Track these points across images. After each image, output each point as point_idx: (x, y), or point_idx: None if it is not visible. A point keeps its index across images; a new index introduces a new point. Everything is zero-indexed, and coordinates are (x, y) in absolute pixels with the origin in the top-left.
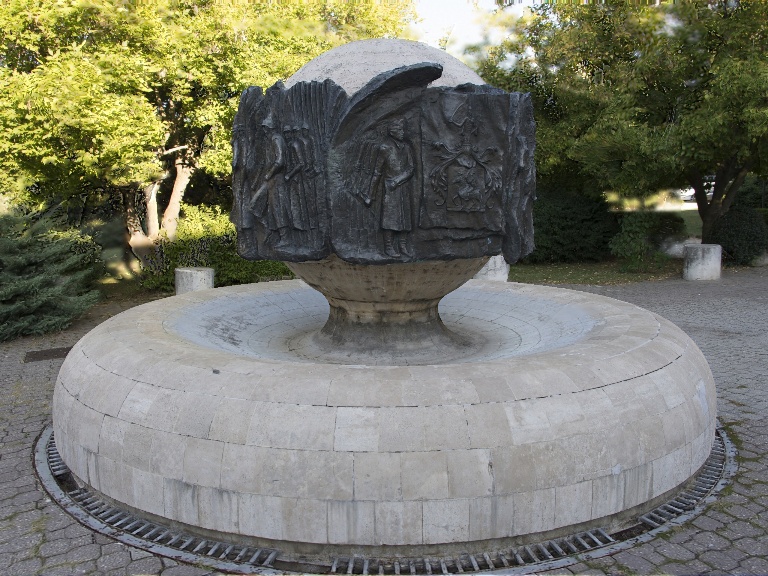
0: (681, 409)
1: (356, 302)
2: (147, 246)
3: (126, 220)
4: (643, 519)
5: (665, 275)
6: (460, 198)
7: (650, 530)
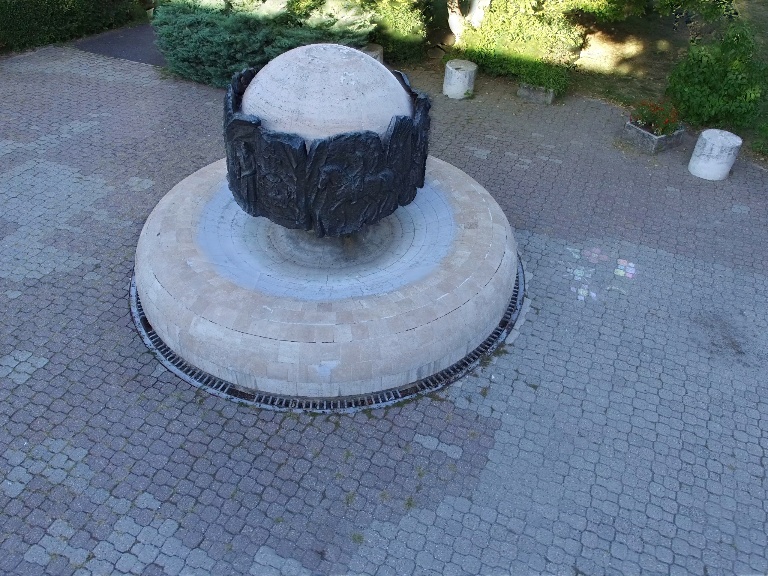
0: (290, 365)
1: None
2: (460, 26)
3: (447, 1)
4: (257, 395)
5: None
6: None
7: (247, 400)
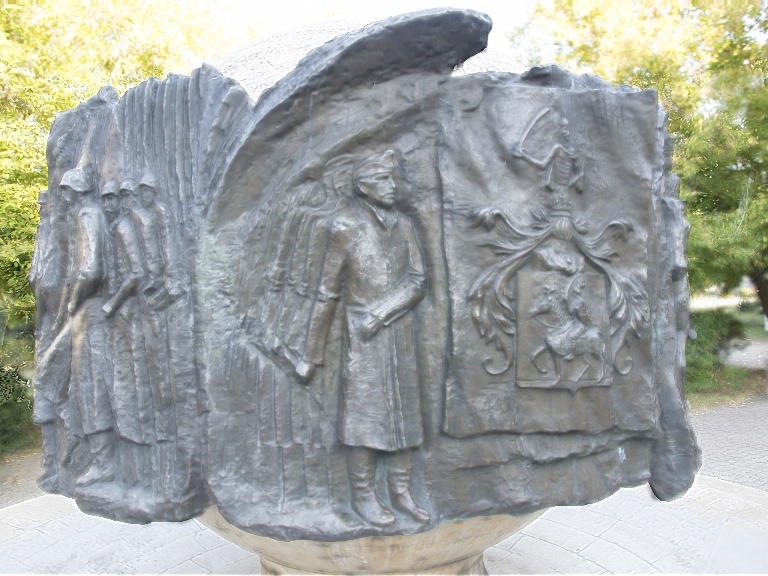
0: None
1: (304, 572)
2: None
3: None
4: None
5: (748, 399)
6: (551, 354)
7: None
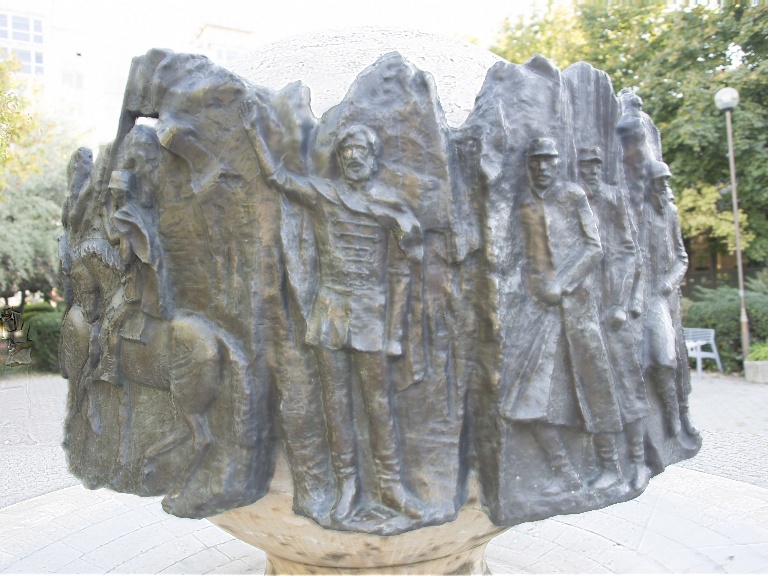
0: None
1: None
2: None
3: None
4: None
5: None
6: None
7: None
